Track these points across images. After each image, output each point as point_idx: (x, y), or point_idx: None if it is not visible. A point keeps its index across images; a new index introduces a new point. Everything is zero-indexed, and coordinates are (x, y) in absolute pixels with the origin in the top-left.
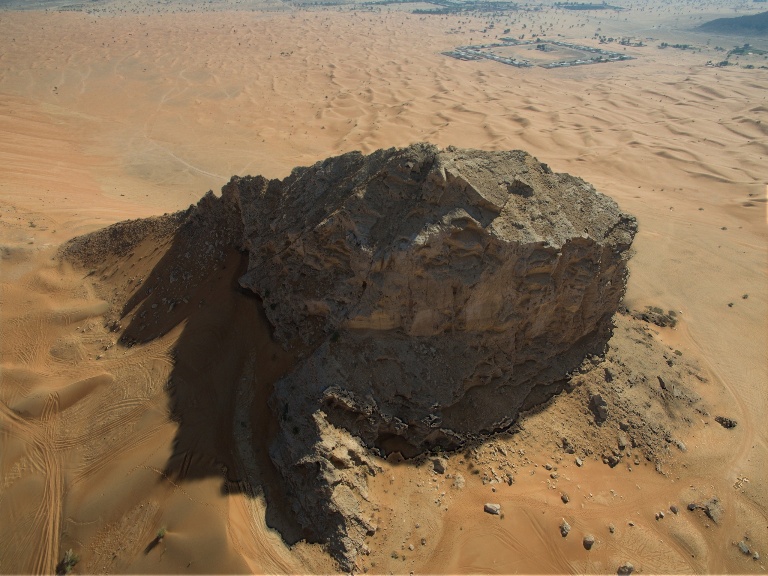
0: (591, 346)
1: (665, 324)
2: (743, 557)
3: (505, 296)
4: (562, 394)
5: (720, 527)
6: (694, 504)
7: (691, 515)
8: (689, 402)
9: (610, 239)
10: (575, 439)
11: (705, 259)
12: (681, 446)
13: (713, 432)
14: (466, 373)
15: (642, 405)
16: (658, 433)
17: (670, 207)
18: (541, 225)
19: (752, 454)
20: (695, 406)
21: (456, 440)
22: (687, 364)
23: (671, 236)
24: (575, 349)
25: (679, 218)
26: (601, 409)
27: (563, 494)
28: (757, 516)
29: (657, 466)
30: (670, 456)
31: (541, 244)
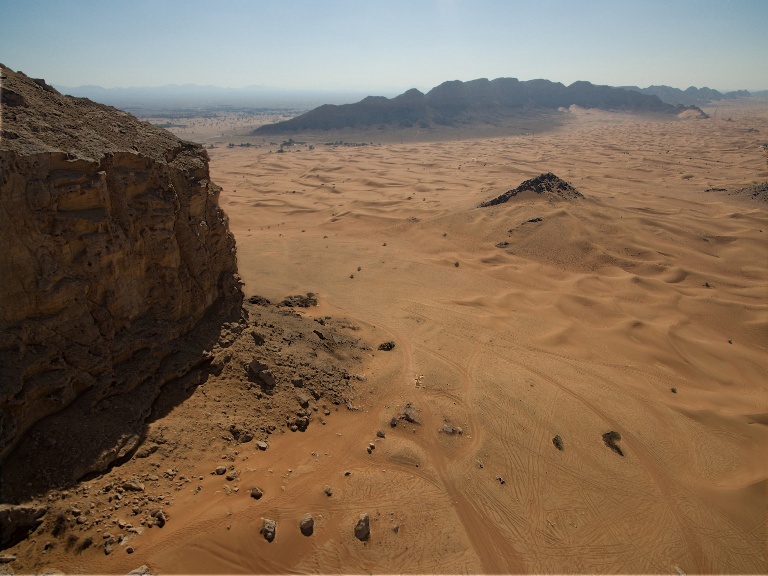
0: (224, 315)
1: (308, 305)
2: (452, 438)
3: (34, 250)
4: (209, 380)
5: (424, 425)
6: (394, 418)
7: (397, 431)
8: (351, 344)
9: (176, 165)
10: (247, 422)
11: (320, 257)
12: (360, 377)
13: (381, 358)
14: (2, 393)
15: (308, 356)
16: (334, 375)
17: (279, 235)
18: (53, 138)
19: (416, 358)
20: (358, 346)
21: (23, 516)
22: (338, 322)
23: (288, 250)
24: (205, 323)
25: (289, 239)
26: (264, 374)
27: (251, 489)
28: (443, 400)
29: (348, 405)
30: (355, 391)
31: (61, 158)
